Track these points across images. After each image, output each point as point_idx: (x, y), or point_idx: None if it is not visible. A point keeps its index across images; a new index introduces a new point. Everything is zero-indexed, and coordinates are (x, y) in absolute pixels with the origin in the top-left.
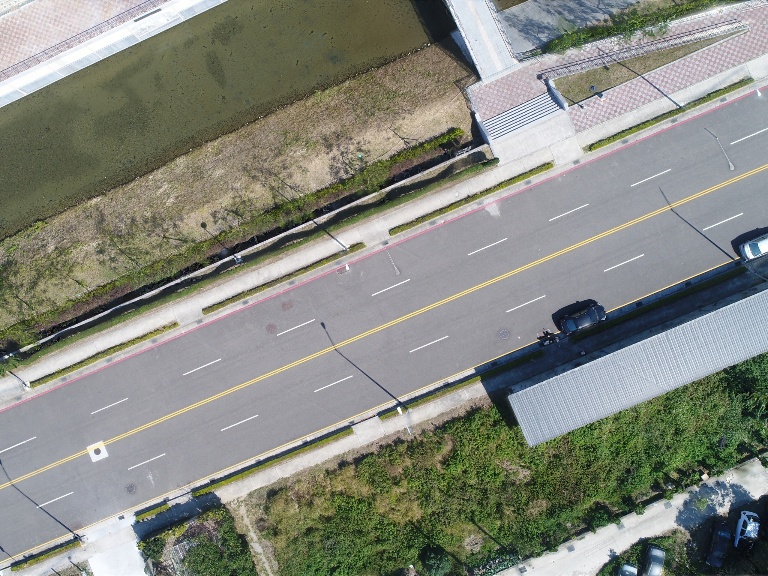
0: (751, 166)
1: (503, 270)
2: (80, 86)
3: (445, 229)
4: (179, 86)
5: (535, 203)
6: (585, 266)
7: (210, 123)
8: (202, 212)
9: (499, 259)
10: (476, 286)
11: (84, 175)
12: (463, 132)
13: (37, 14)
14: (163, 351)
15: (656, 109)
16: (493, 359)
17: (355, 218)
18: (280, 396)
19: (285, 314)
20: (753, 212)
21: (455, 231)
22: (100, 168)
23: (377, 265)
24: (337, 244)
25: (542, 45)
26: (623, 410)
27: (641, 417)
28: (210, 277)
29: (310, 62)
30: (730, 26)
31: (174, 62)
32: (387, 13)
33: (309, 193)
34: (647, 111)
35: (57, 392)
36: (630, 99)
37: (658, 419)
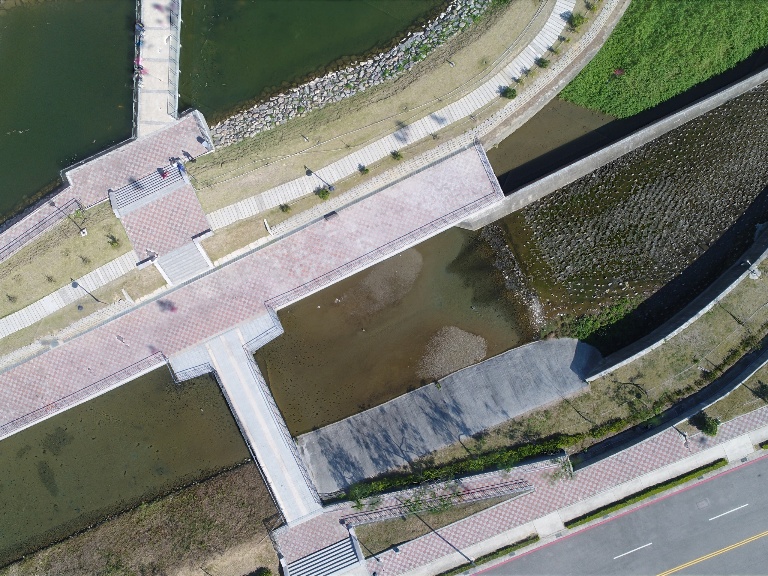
0: None
1: None
2: None
3: None
4: (12, 494)
5: None
6: None
7: (43, 530)
8: None
9: None
10: None
11: None
12: (269, 575)
13: None
14: None
15: (448, 563)
16: None
17: None
18: None
19: None
20: None
21: None
22: None
23: None
24: None
25: (346, 487)
26: None
27: None
28: None
29: (137, 473)
30: (518, 485)
31: (7, 471)
32: (210, 428)
33: None
34: (440, 564)
35: None
36: (424, 553)
37: None
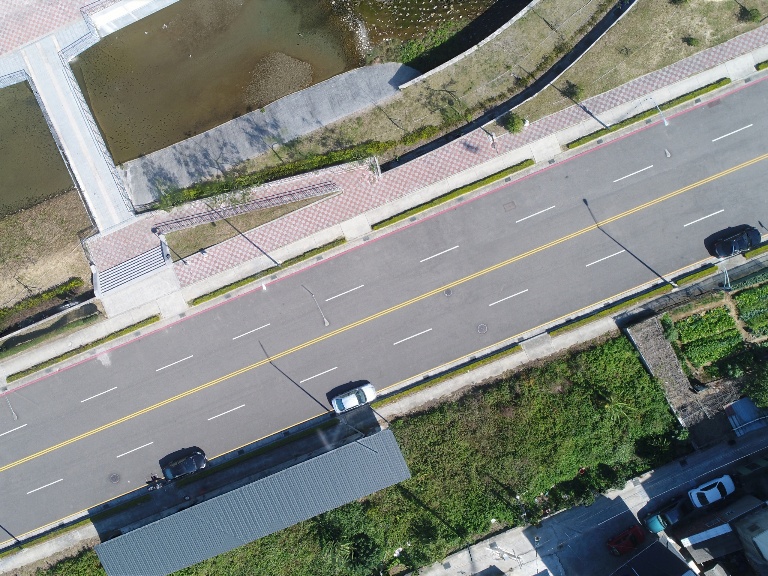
0: (344, 322)
1: (113, 417)
2: None
3: (60, 377)
4: None
5: (143, 354)
6: (190, 415)
7: None
8: None
9: (109, 407)
10: (88, 432)
11: None
12: (80, 283)
13: None
14: None
15: (256, 266)
16: (105, 502)
17: None
18: None
19: None
20: (346, 366)
21: (69, 379)
22: None
23: None
24: None
25: (160, 198)
26: (219, 555)
27: (236, 562)
28: None
29: None
30: (326, 188)
31: None
32: (37, 156)
33: None
34: (247, 268)
35: None
36: (231, 256)
37: (253, 564)
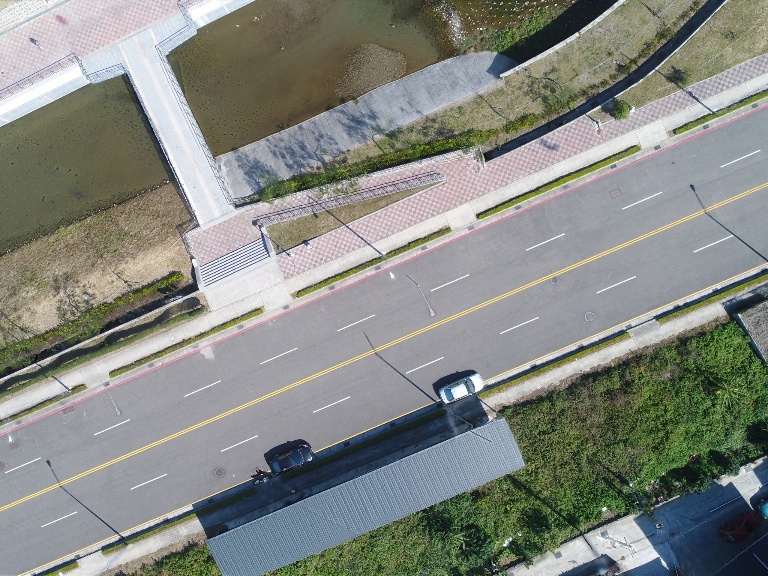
0: (450, 312)
1: (217, 411)
2: None
3: (163, 371)
4: None
5: (247, 347)
6: (295, 408)
7: None
8: None
9: (213, 401)
10: (192, 426)
11: None
12: (181, 277)
13: None
14: None
15: (360, 257)
16: (210, 496)
17: (69, 365)
18: (9, 531)
19: (13, 452)
20: (453, 356)
21: (172, 373)
22: None
23: (99, 406)
24: (60, 386)
25: (259, 191)
26: None
27: (345, 554)
28: None
29: (56, 198)
30: (429, 177)
31: None
32: (128, 150)
33: (38, 334)
34: (351, 259)
35: None
36: (335, 247)
37: (362, 556)
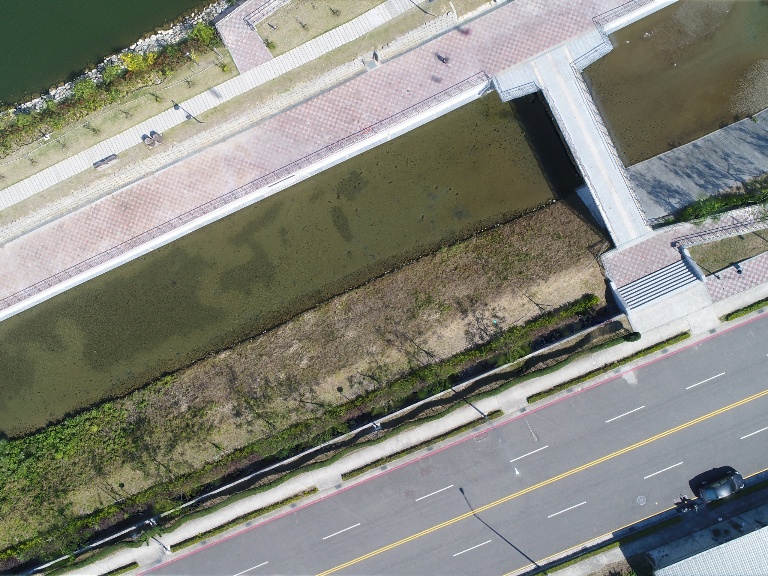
0: None
1: (640, 437)
2: (206, 240)
3: (582, 397)
4: (305, 241)
5: (672, 371)
6: (722, 434)
7: (336, 277)
8: (338, 377)
9: (636, 426)
10: (614, 453)
11: (211, 328)
12: (598, 300)
13: (171, 180)
14: (302, 515)
15: None
16: (631, 524)
17: (497, 391)
18: (419, 560)
19: (424, 480)
20: None
21: (592, 399)
22: (226, 321)
23: (515, 432)
24: (475, 411)
25: (674, 211)
26: None
27: None
28: (349, 444)
29: (435, 217)
30: None
31: (300, 217)
32: (512, 169)
33: (444, 358)
34: None
35: (197, 555)
36: (766, 270)
37: None
